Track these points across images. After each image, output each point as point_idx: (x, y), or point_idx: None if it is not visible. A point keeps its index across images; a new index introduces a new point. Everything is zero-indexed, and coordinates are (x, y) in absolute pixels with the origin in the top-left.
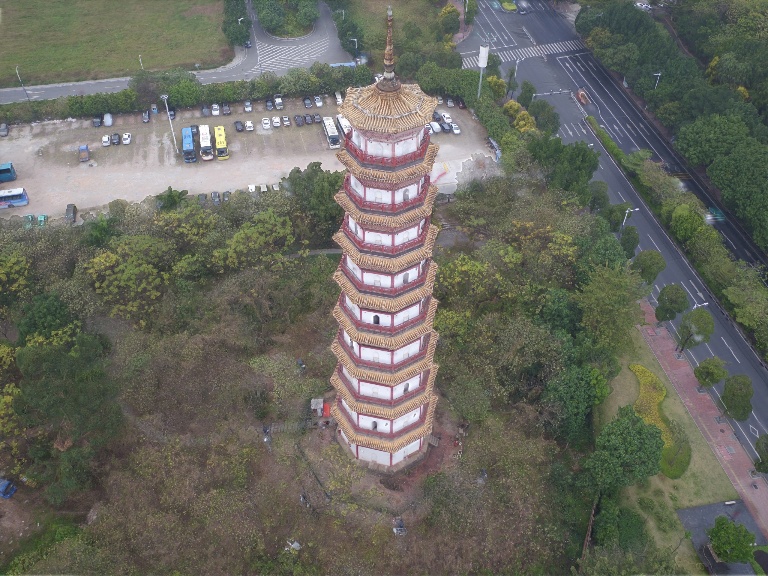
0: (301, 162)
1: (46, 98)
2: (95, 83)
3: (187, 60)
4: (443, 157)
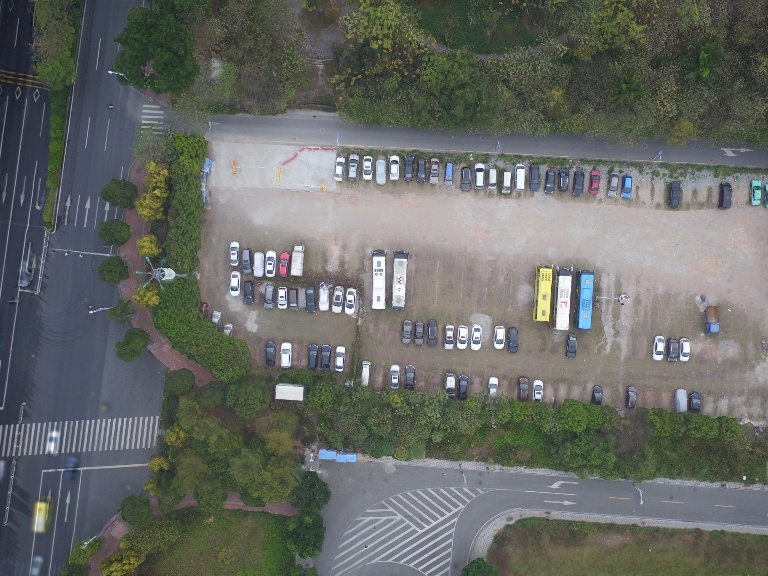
0: (450, 235)
1: (764, 493)
2: (697, 521)
3: (561, 557)
4: (273, 198)
